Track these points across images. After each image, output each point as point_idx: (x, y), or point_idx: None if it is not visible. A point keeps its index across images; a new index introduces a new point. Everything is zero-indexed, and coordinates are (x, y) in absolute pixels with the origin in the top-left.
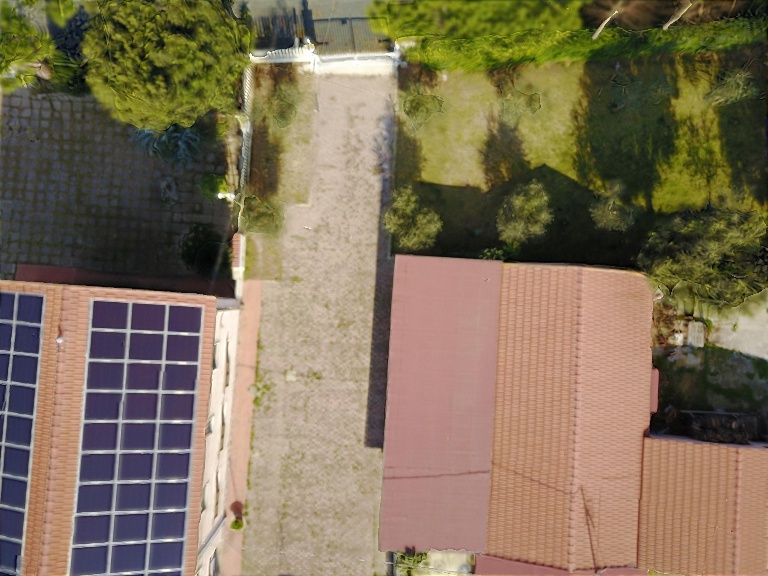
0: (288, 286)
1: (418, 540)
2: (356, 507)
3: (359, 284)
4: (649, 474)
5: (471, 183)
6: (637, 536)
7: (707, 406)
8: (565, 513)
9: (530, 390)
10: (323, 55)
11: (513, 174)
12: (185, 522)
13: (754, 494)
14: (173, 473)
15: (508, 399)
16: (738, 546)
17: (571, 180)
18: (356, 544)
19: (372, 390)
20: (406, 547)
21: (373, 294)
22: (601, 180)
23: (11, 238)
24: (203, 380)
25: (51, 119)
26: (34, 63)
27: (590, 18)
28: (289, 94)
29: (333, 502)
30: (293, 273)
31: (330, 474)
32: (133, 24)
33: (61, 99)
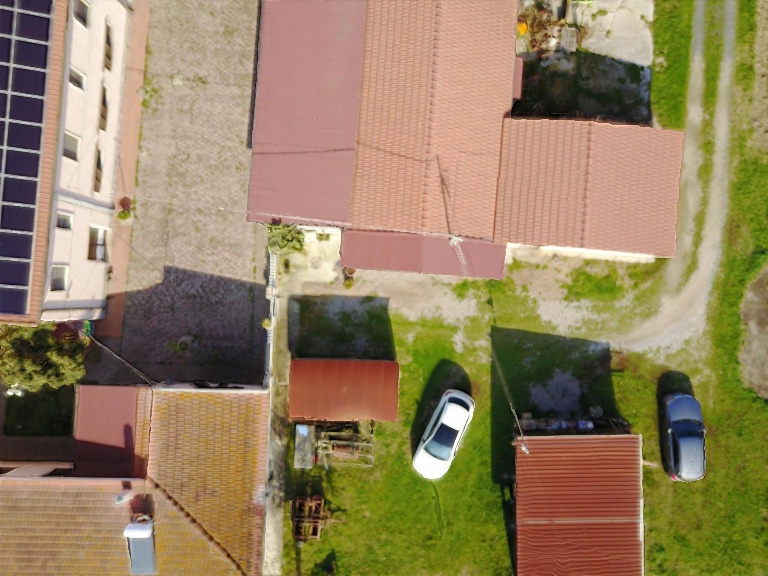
0: None
1: (284, 212)
2: (238, 205)
3: None
4: (507, 152)
5: None
6: (494, 212)
7: (577, 109)
8: (421, 181)
9: (393, 70)
10: None
11: None
12: (41, 136)
13: (606, 166)
14: (29, 88)
15: (373, 81)
16: (588, 215)
17: None
18: (238, 239)
19: None
20: (273, 218)
21: (257, 3)
22: None
23: None
24: (59, 7)
25: None
26: None
27: None
28: None
29: (216, 200)
30: None
31: (214, 173)
32: None
33: None
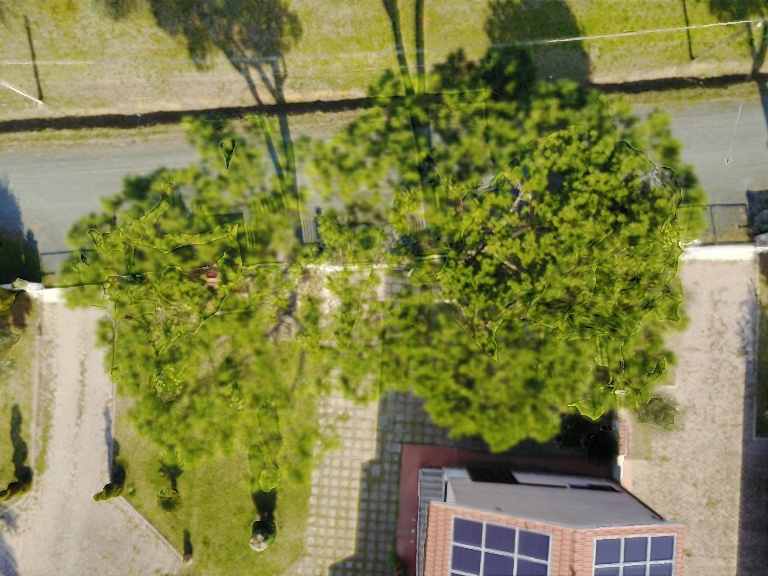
0: (658, 465)
1: None
2: None
3: (725, 463)
4: None
5: None
6: None
7: None
8: None
9: None
10: None
11: None
12: None
13: None
14: None
15: None
16: None
17: None
18: None
19: (740, 567)
20: None
21: (739, 473)
22: None
23: (396, 418)
24: None
25: (430, 305)
26: (422, 256)
27: None
28: None
29: None
30: (662, 453)
31: None
32: (616, 273)
33: None
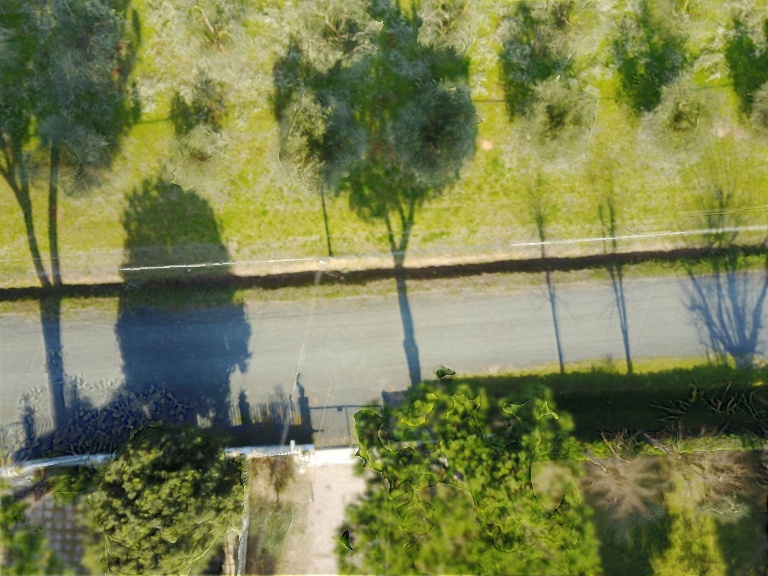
0: None
1: None
2: None
3: None
4: None
5: (464, 574)
6: None
7: None
8: None
9: None
10: (318, 442)
11: (505, 565)
12: None
13: None
14: None
15: None
16: None
17: (563, 573)
18: None
19: None
20: None
21: None
22: (593, 573)
23: None
24: None
25: (54, 509)
26: (38, 463)
27: (583, 398)
28: (285, 483)
29: None
30: None
31: None
32: (128, 542)
33: (64, 493)
